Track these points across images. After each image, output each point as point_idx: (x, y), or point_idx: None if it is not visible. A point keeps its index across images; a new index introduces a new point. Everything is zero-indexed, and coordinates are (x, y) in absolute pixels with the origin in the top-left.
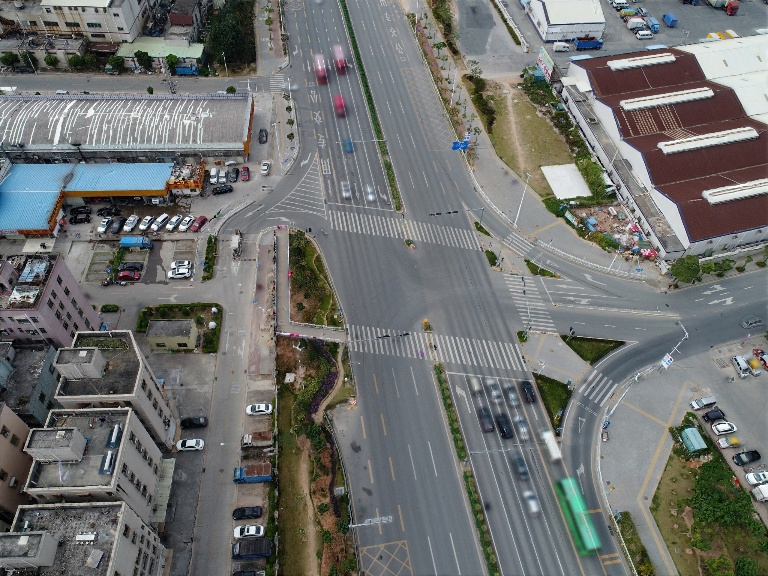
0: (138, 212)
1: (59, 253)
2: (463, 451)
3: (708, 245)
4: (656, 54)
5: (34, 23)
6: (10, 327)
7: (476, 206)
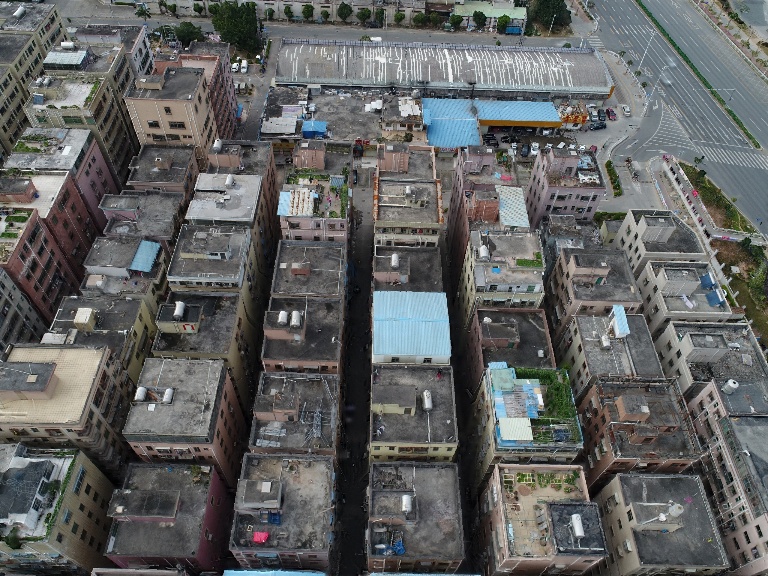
0: (534, 141)
1: None
2: None
3: None
4: None
5: None
6: (568, 205)
7: None
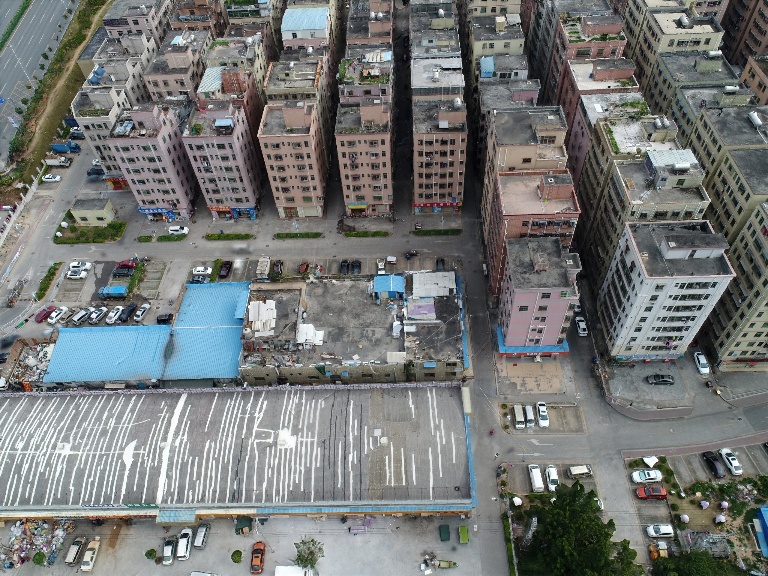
0: None
1: None
2: None
3: None
4: None
5: None
6: None
7: None
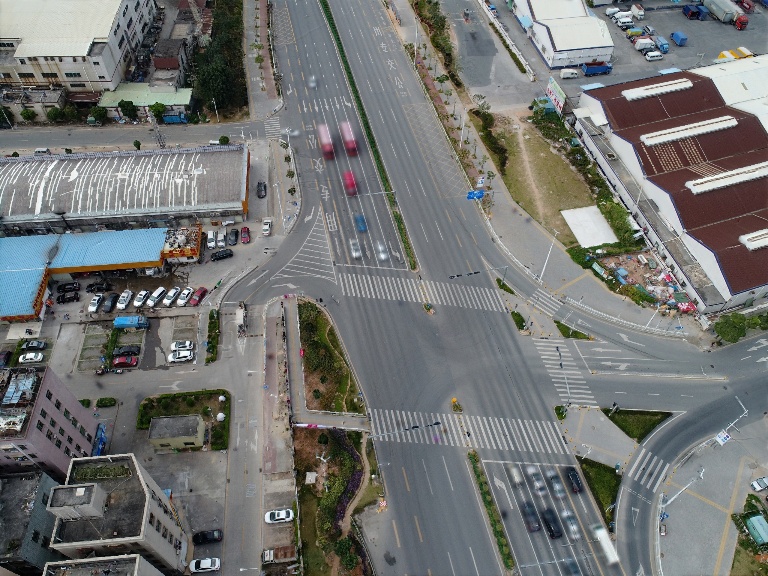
0: (131, 285)
1: (47, 338)
2: (509, 558)
3: (749, 295)
4: (672, 80)
5: (8, 75)
6: None
7: (496, 260)
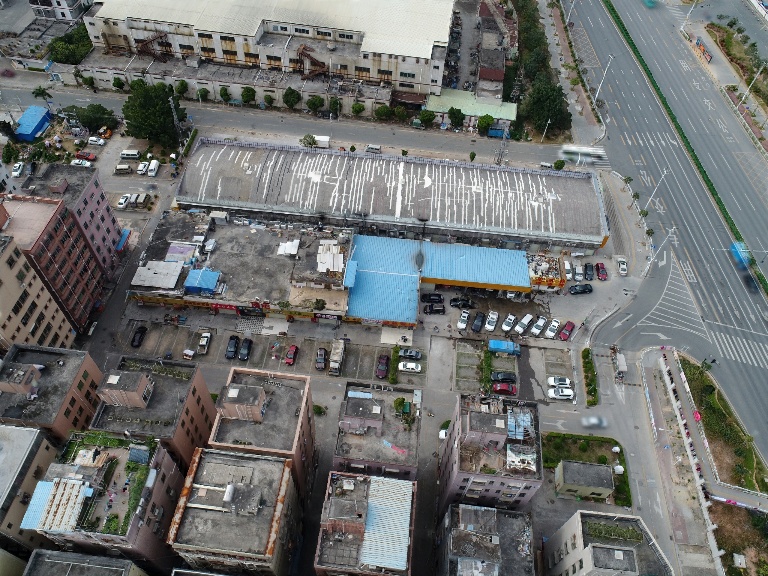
0: (493, 306)
1: (419, 349)
2: None
3: None
4: None
5: (345, 67)
6: (490, 488)
7: None
